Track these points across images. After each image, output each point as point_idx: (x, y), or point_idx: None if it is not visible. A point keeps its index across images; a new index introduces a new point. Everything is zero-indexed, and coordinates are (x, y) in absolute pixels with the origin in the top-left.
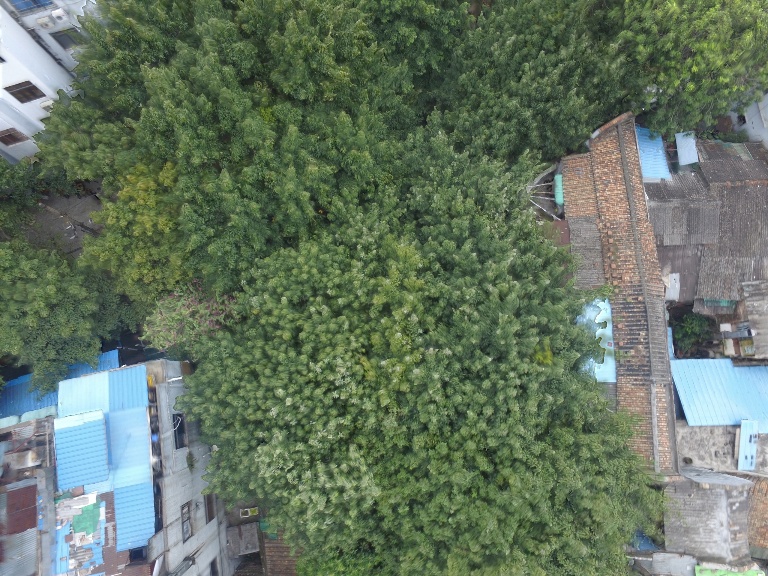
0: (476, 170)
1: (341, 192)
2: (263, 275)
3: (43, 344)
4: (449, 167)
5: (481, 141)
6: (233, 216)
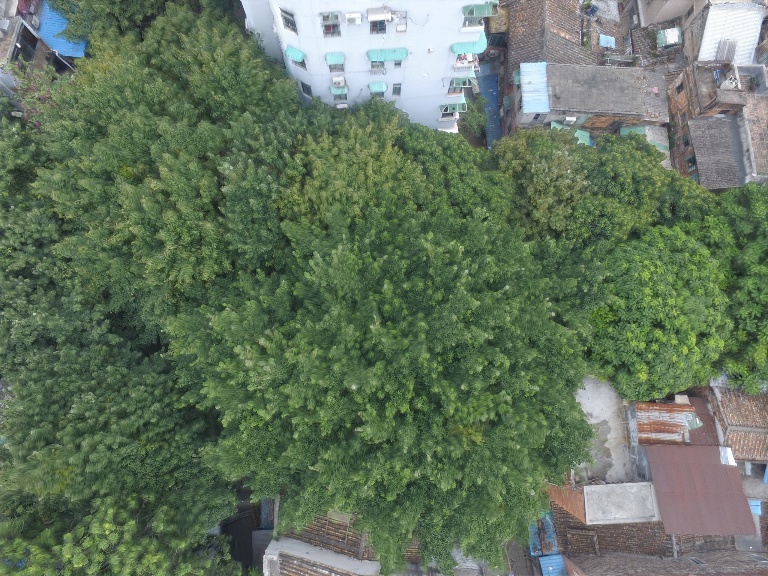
0: (4, 343)
1: (77, 231)
2: (14, 145)
3: (72, 2)
4: (15, 318)
5: (33, 360)
6: (47, 126)
